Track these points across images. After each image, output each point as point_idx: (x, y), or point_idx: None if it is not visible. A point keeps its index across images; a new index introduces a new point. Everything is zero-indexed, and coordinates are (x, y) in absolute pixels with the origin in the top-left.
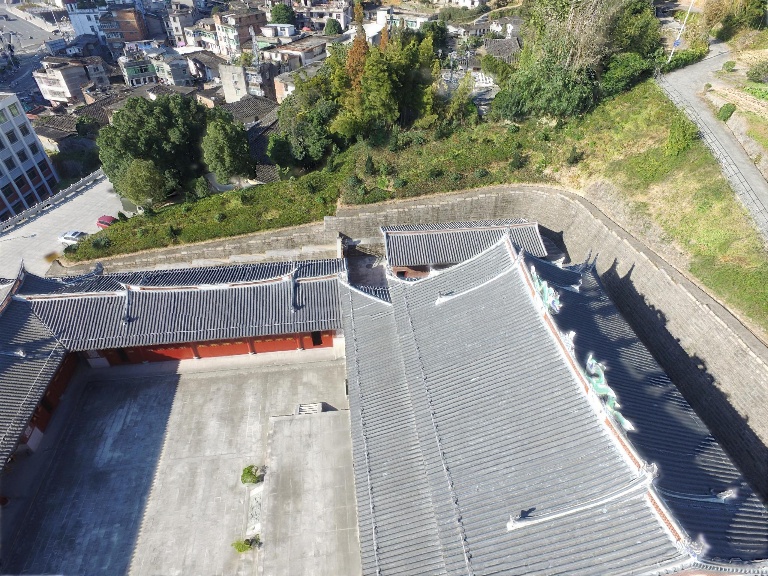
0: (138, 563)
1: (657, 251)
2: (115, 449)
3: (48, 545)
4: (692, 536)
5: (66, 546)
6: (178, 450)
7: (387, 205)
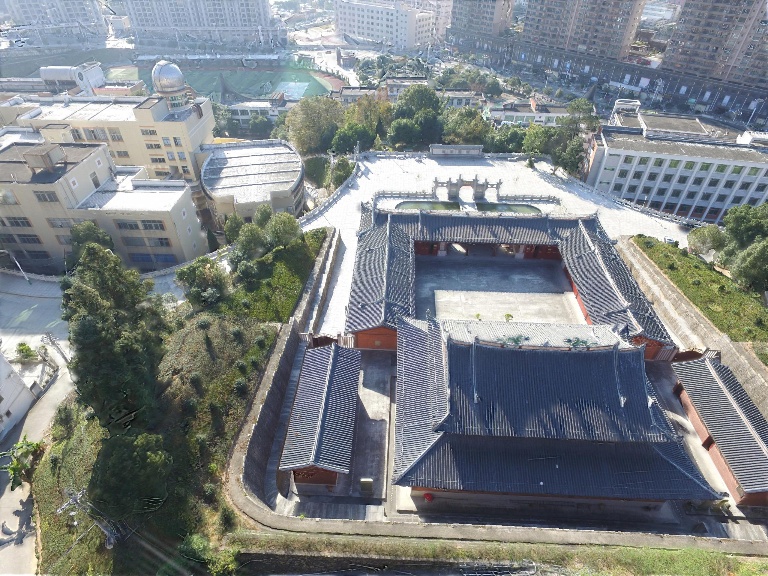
0: (473, 293)
1: (759, 558)
2: (519, 279)
3: (479, 271)
4: (457, 361)
5: (479, 275)
6: (521, 297)
7: (767, 374)
